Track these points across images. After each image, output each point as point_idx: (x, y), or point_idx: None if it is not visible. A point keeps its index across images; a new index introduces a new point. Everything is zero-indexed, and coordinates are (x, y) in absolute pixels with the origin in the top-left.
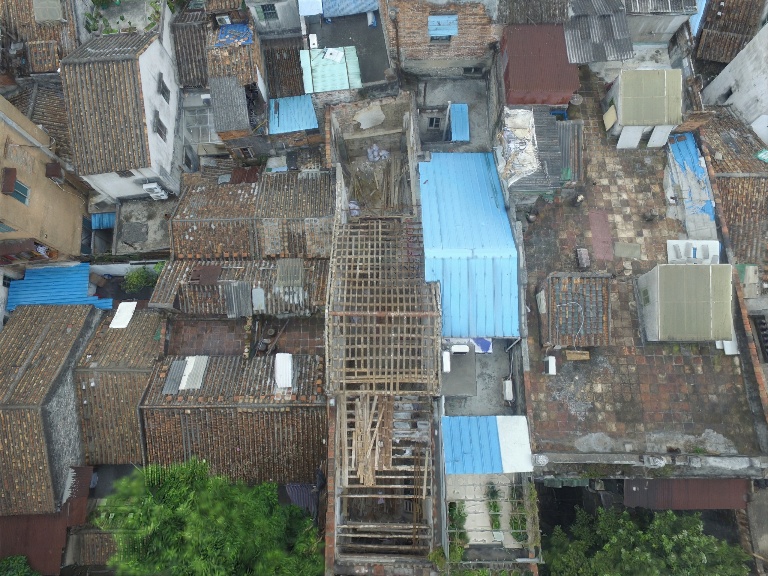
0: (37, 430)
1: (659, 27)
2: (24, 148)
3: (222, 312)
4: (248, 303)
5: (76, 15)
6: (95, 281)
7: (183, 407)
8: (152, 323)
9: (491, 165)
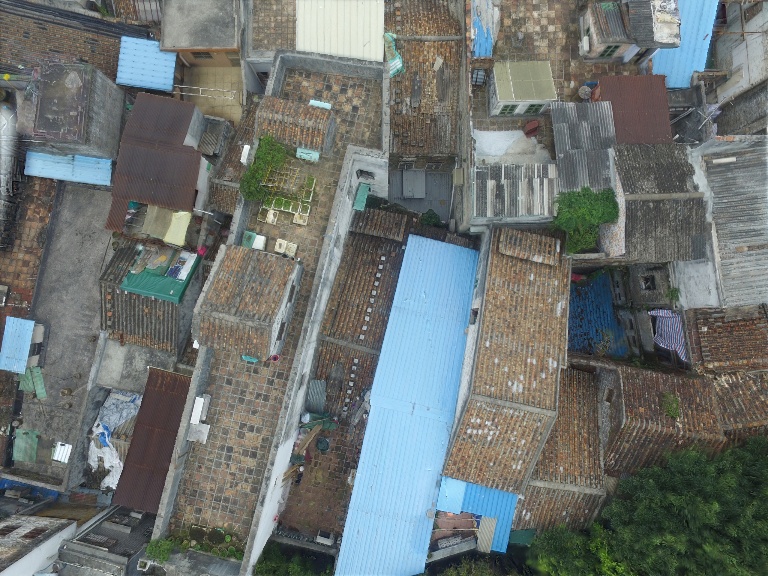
0: None
1: None
2: None
3: None
4: None
5: None
6: None
7: None
8: None
9: None
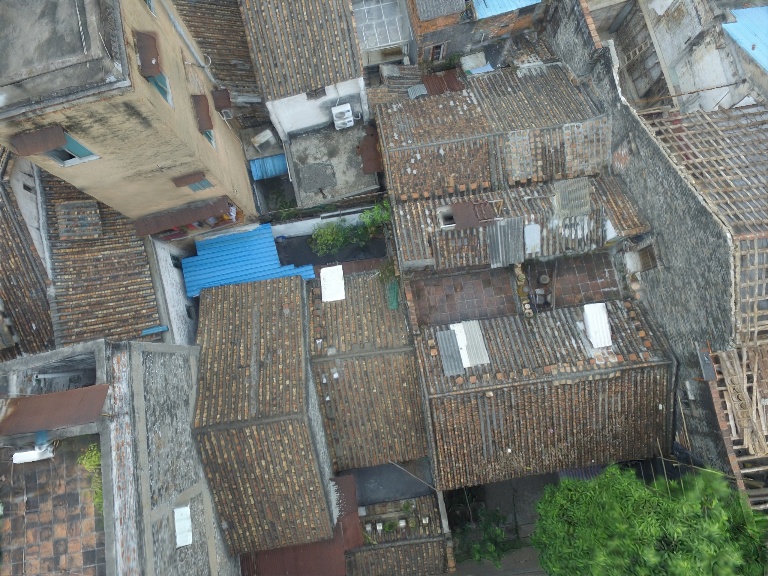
0: (303, 444)
1: None
2: (194, 68)
3: (483, 262)
4: (519, 246)
5: None
6: None
7: (484, 389)
8: (375, 289)
9: None
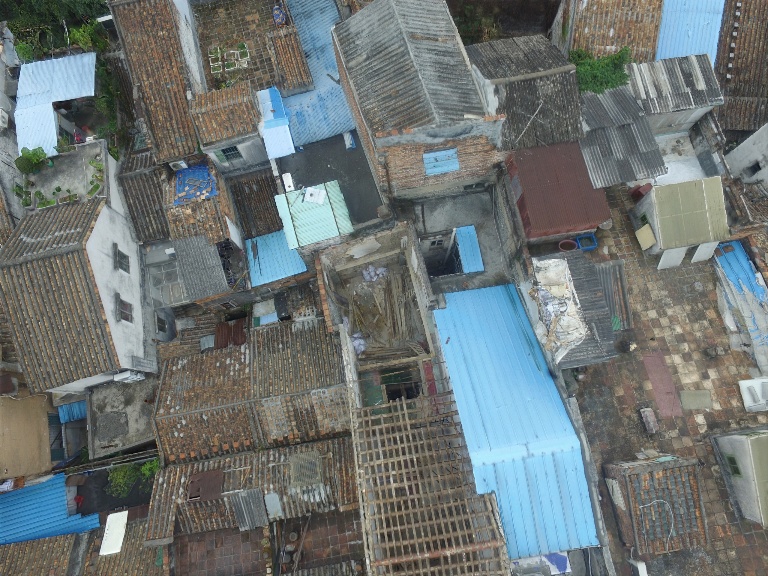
0: None
1: (679, 119)
2: None
3: (232, 526)
4: (262, 511)
5: (2, 186)
6: (74, 483)
7: None
8: None
9: (517, 303)
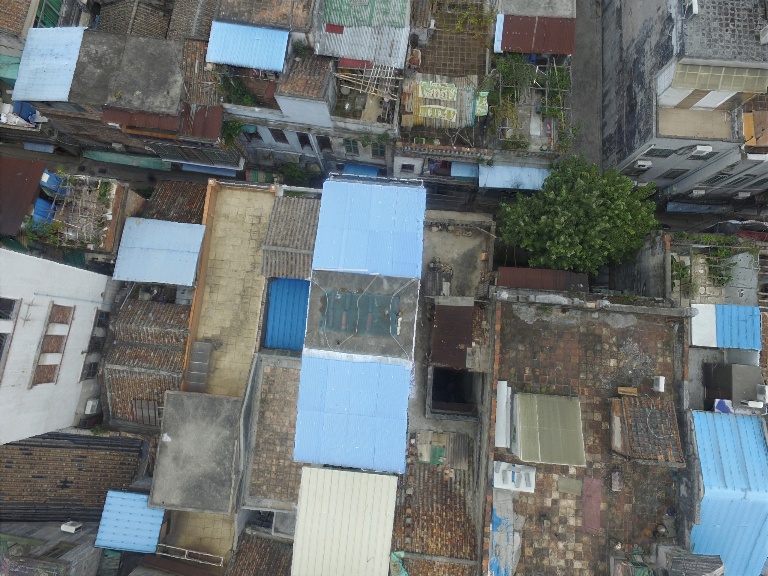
0: None
1: None
2: None
3: None
4: None
5: None
6: None
7: None
8: None
9: None
